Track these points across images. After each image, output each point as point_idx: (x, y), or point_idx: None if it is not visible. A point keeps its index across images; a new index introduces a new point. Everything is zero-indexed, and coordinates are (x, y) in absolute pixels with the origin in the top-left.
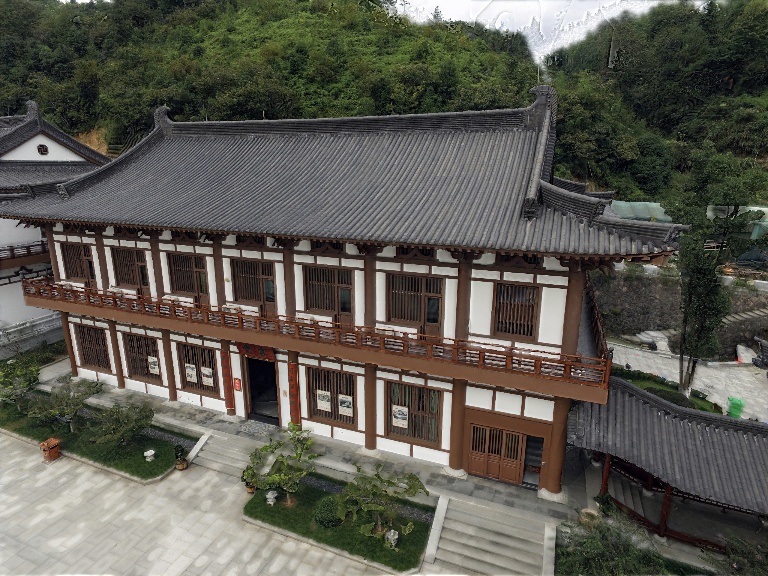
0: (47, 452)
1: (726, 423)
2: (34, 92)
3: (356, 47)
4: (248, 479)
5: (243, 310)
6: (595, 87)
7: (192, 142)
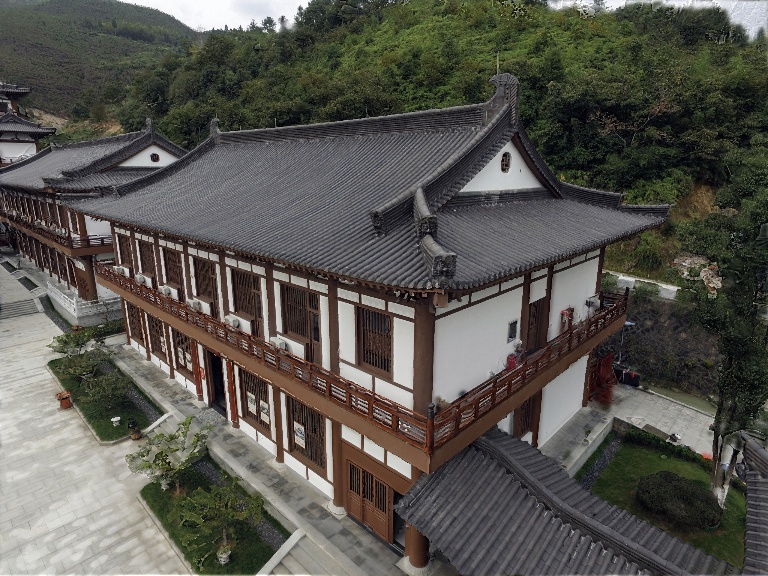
0: (60, 401)
1: (616, 545)
2: (212, 110)
3: (475, 46)
4: (127, 460)
5: (187, 305)
6: (763, 67)
7: (229, 150)
